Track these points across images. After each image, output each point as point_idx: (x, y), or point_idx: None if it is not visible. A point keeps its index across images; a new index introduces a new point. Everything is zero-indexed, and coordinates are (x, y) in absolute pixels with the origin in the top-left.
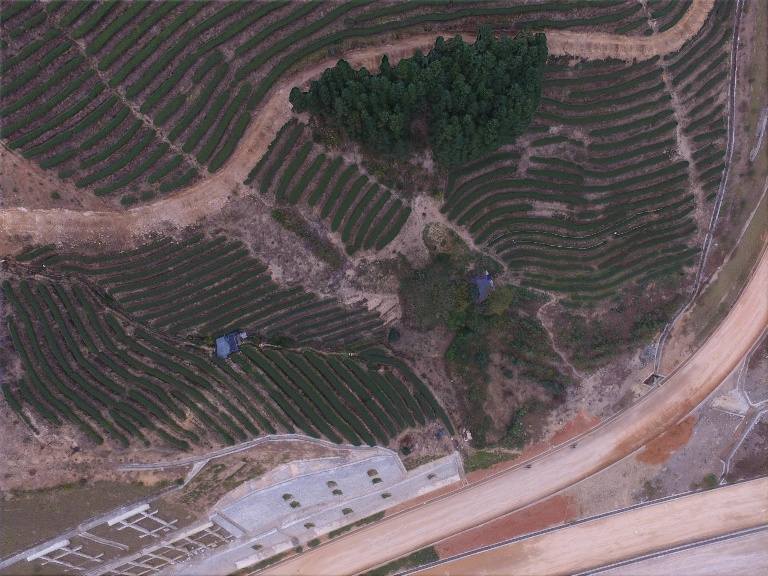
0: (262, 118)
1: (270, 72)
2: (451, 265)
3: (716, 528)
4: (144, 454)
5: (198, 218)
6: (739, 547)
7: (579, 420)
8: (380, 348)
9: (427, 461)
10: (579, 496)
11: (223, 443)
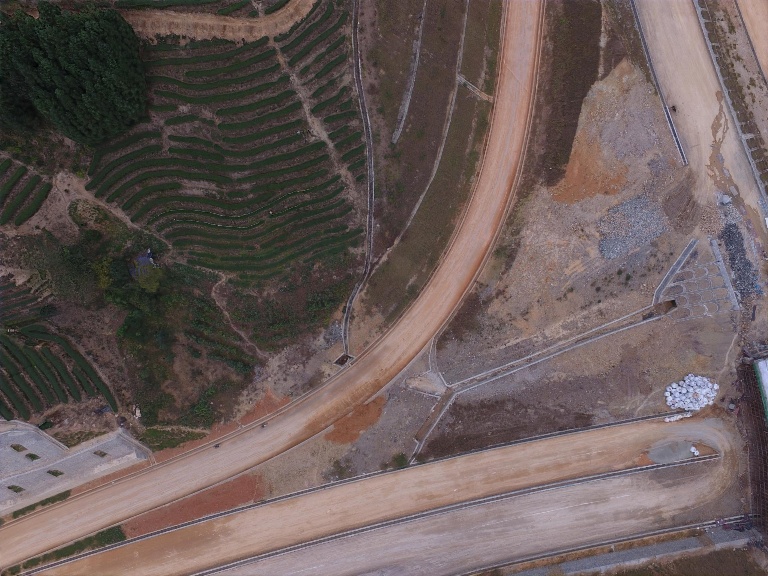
0: None
1: None
2: (109, 242)
3: (408, 507)
4: None
5: None
6: (431, 526)
7: (268, 399)
8: (42, 325)
9: (88, 437)
10: (267, 475)
11: None
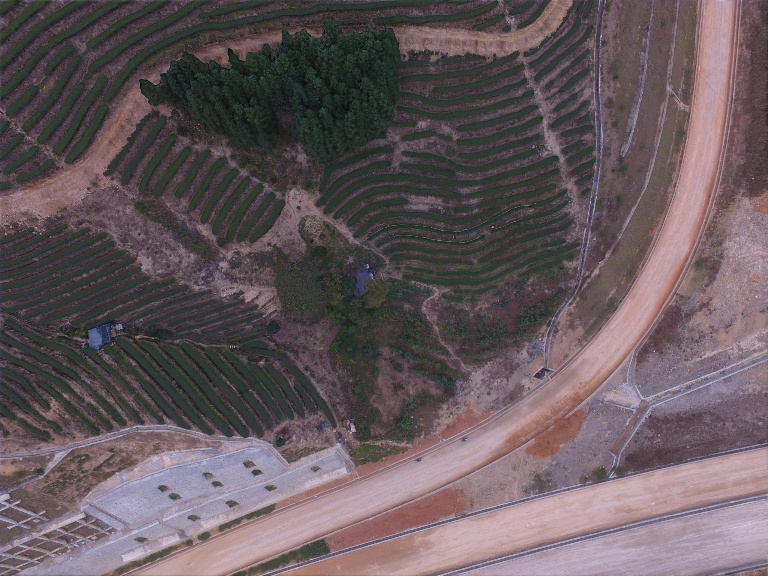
0: (122, 110)
1: (126, 65)
2: (331, 258)
3: (607, 521)
4: (2, 443)
5: (58, 209)
6: (629, 540)
7: (469, 413)
8: (262, 341)
9: (308, 453)
10: (469, 489)
11: (87, 433)
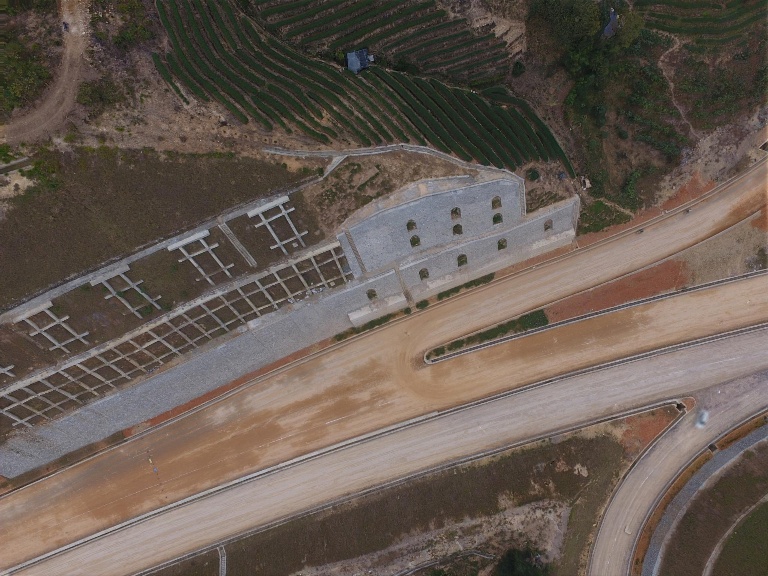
0: None
1: None
2: None
3: None
4: (287, 139)
5: None
6: None
7: (693, 184)
8: (501, 88)
9: (547, 203)
10: (692, 261)
11: (359, 143)
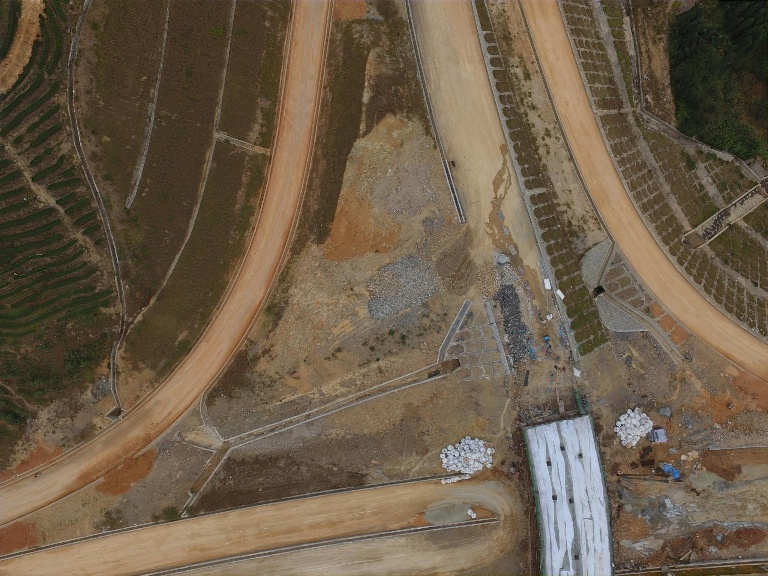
0: None
1: None
2: None
3: (180, 559)
4: None
5: None
6: None
7: (41, 450)
8: None
9: None
10: (40, 523)
11: None
